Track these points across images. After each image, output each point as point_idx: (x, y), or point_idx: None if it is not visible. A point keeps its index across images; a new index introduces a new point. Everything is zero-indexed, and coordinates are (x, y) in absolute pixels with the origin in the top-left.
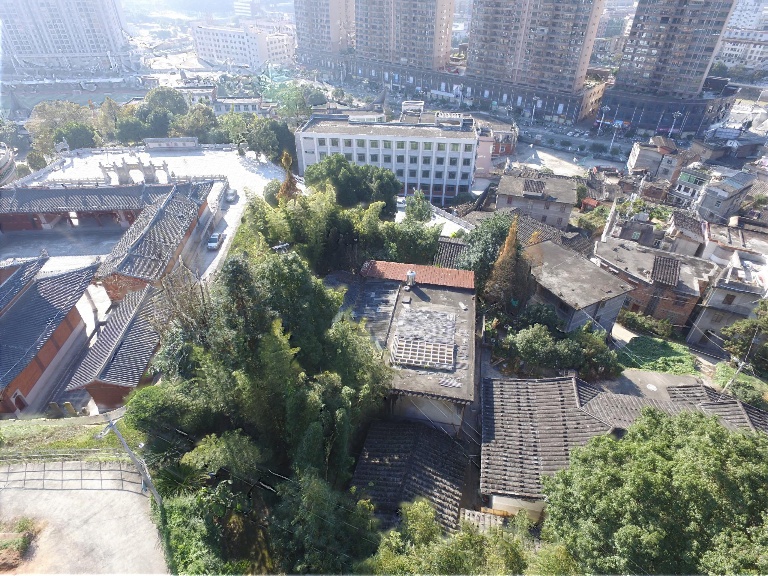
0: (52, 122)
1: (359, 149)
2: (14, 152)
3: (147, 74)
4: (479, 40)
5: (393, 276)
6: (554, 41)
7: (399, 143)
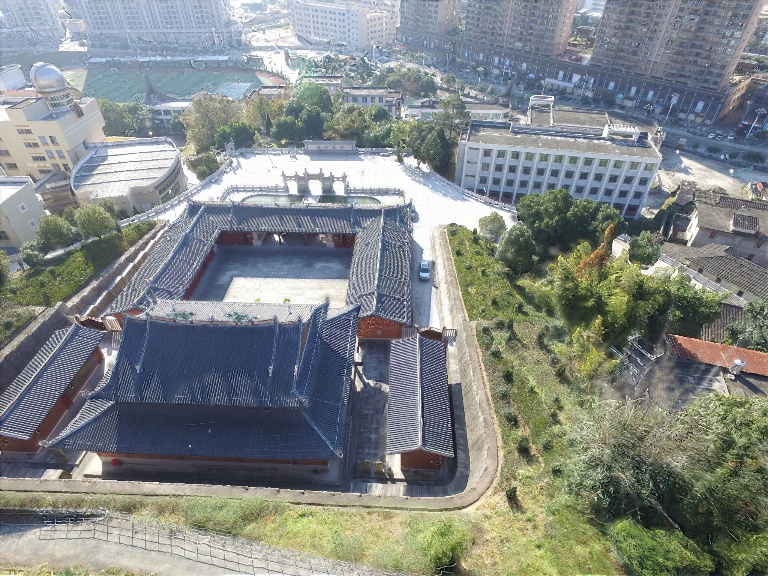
0: (205, 116)
1: (526, 162)
2: (150, 136)
3: (248, 51)
4: (612, 27)
5: (710, 360)
6: (703, 31)
7: (572, 158)
